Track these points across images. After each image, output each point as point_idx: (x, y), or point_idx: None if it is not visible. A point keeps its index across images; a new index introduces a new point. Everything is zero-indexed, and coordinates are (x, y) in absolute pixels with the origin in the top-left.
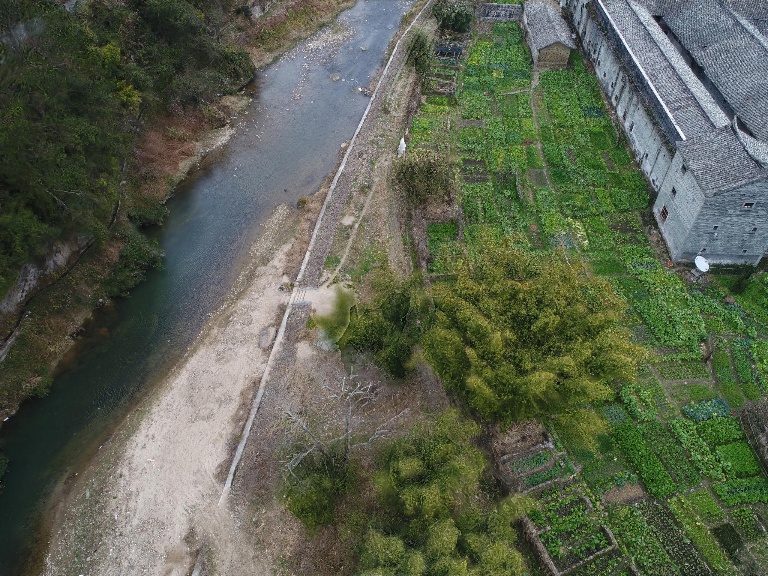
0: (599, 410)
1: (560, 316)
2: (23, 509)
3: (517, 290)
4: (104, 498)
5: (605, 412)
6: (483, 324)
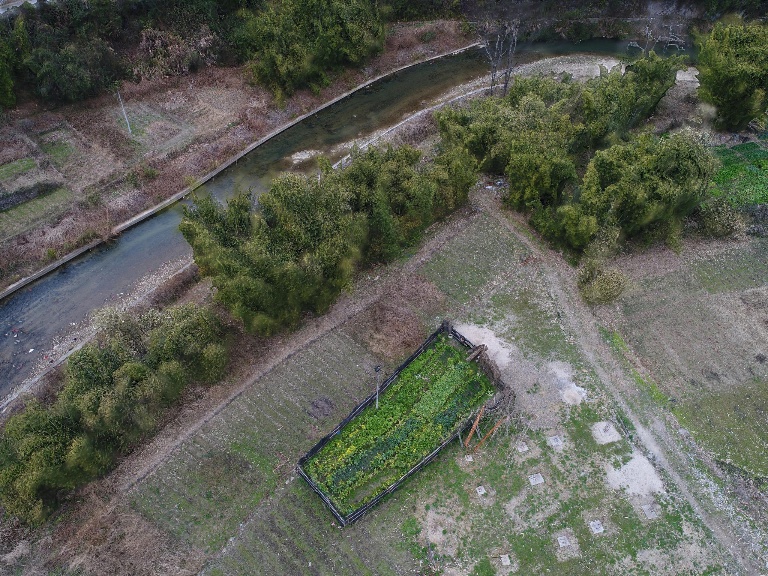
0: (750, 163)
1: (765, 58)
2: (574, 50)
3: (767, 41)
4: (590, 60)
5: (751, 166)
6: (732, 30)
